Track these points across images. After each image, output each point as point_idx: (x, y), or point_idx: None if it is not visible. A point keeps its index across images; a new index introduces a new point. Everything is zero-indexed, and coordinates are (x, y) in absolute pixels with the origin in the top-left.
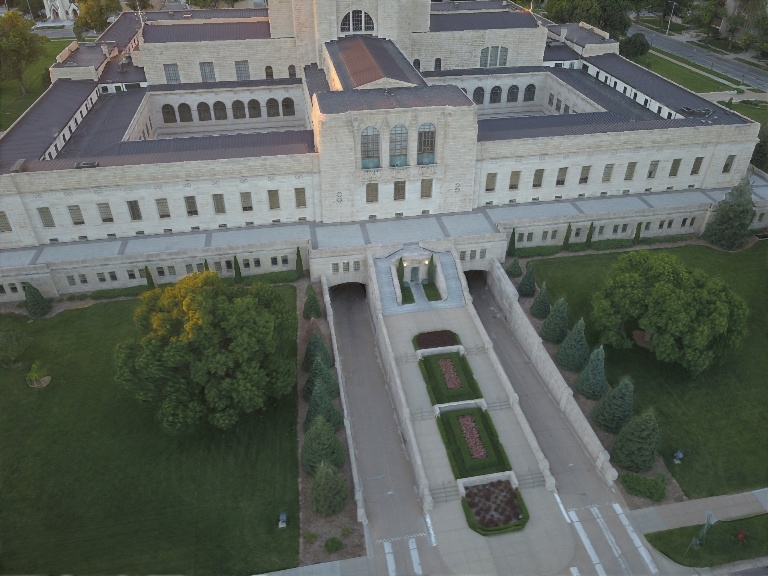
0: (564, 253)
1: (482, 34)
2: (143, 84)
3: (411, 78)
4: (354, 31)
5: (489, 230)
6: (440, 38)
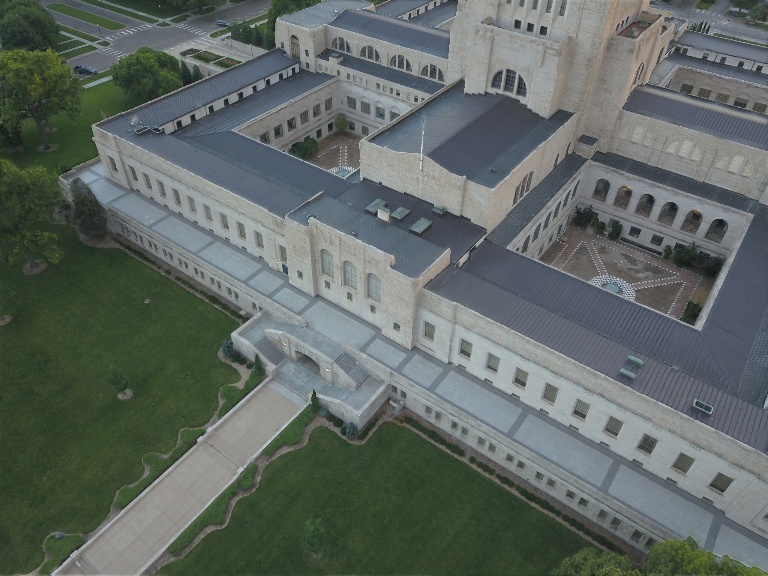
0: None
1: None
2: None
3: (347, 27)
4: None
5: None
6: None
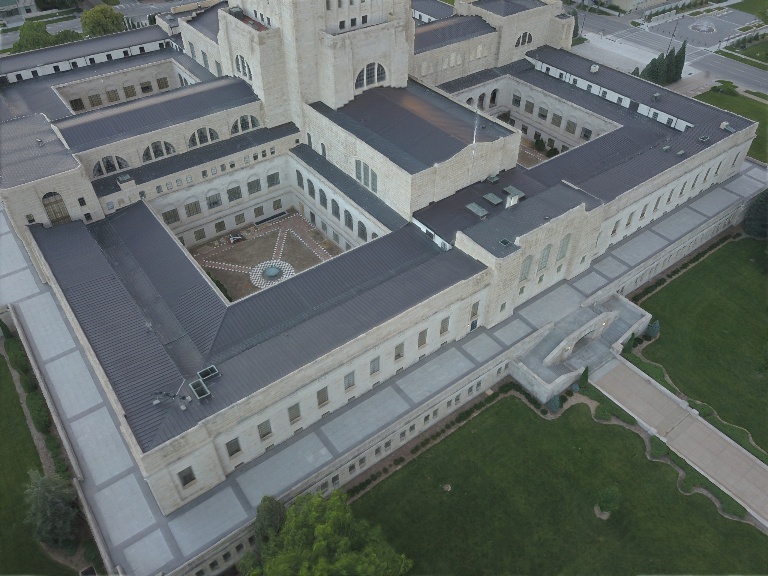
0: (18, 376)
1: (354, 141)
2: (184, 51)
3: (100, 141)
4: (245, 75)
5: (1, 303)
6: (322, 123)
